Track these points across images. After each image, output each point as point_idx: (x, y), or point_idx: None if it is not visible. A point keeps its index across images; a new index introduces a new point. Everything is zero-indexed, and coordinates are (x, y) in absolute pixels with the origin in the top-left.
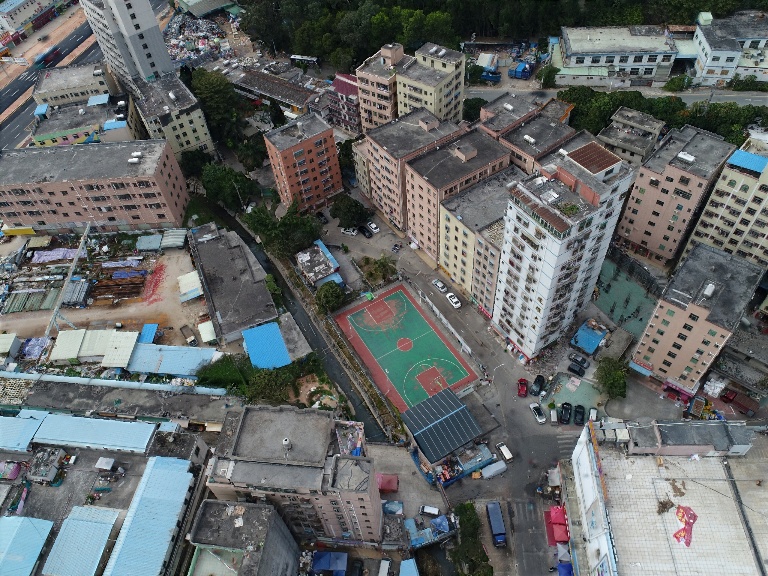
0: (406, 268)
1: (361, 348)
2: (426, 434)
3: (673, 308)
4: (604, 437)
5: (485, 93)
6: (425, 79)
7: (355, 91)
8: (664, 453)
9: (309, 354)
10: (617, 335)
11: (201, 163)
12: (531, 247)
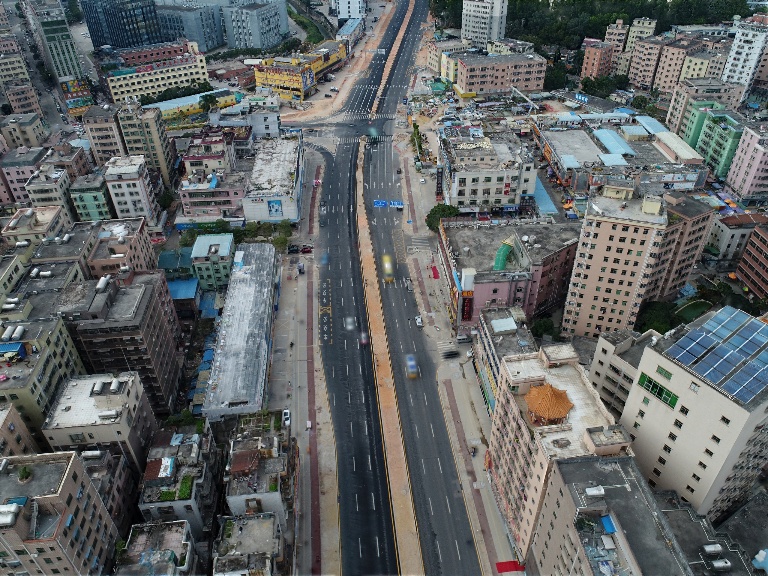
0: None
1: None
2: None
3: None
4: None
5: None
6: None
7: None
8: None
9: None
10: (764, 103)
11: None
12: (748, 44)
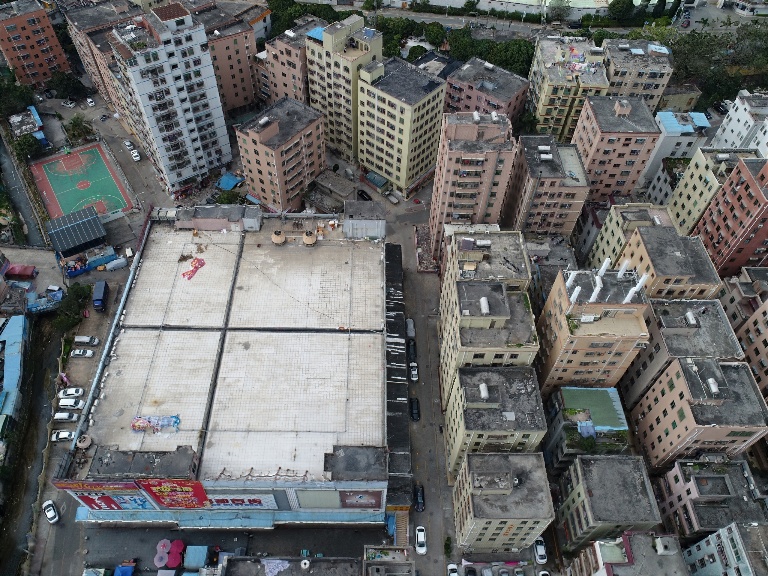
0: (107, 133)
1: (46, 187)
2: (58, 233)
3: (243, 136)
4: (157, 215)
5: (220, 4)
6: None
7: None
8: (201, 228)
9: None
10: None
11: None
12: None
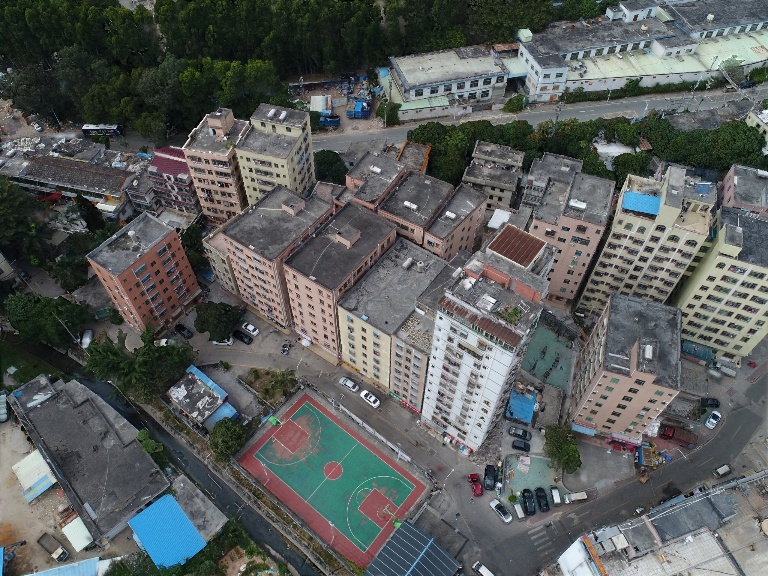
0: (304, 371)
1: (284, 491)
2: None
3: (618, 377)
4: (604, 552)
5: (328, 141)
6: (271, 149)
7: (184, 168)
8: (662, 546)
9: (225, 525)
10: (547, 394)
11: (0, 296)
12: (472, 356)
